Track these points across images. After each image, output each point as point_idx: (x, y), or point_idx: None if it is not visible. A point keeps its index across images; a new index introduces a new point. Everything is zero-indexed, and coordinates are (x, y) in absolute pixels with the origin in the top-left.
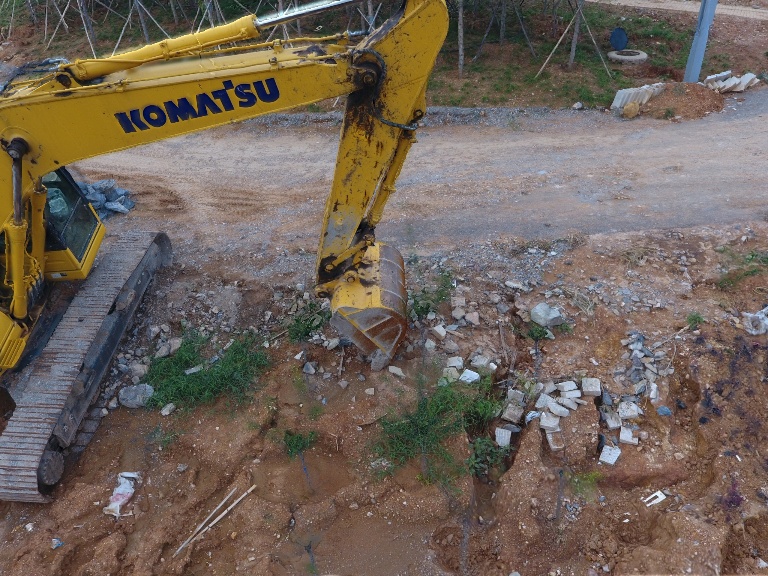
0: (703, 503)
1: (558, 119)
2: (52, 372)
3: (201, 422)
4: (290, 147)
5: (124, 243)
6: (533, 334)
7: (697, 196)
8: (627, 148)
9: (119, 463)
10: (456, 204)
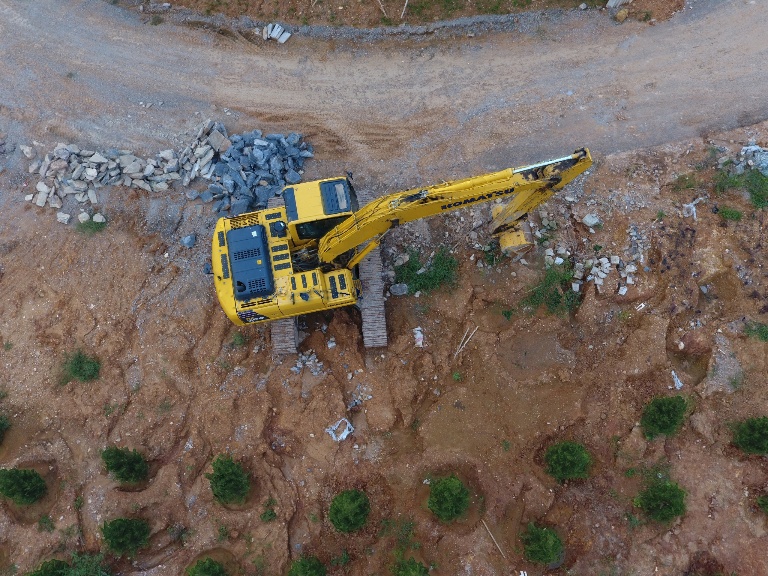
0: (661, 309)
1: (571, 23)
2: (371, 290)
3: (437, 299)
4: (385, 70)
5: (361, 204)
6: (597, 250)
7: (665, 115)
8: (621, 61)
9: (409, 324)
10: (523, 131)
